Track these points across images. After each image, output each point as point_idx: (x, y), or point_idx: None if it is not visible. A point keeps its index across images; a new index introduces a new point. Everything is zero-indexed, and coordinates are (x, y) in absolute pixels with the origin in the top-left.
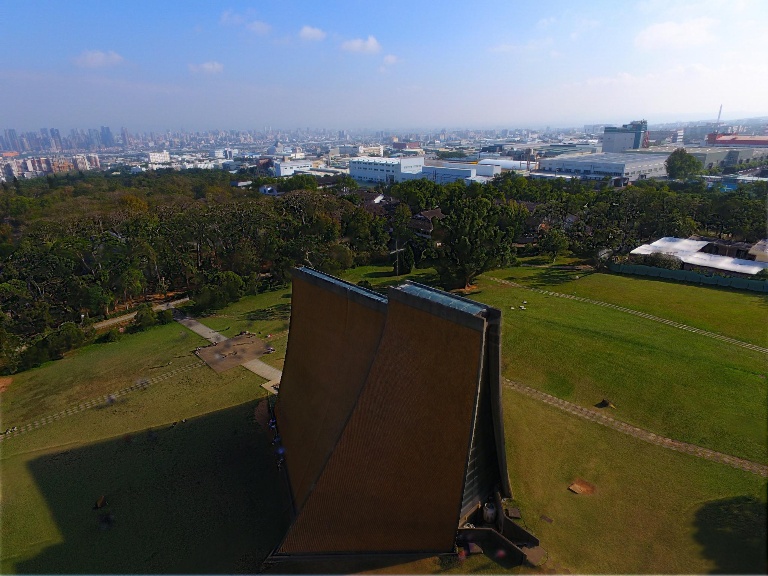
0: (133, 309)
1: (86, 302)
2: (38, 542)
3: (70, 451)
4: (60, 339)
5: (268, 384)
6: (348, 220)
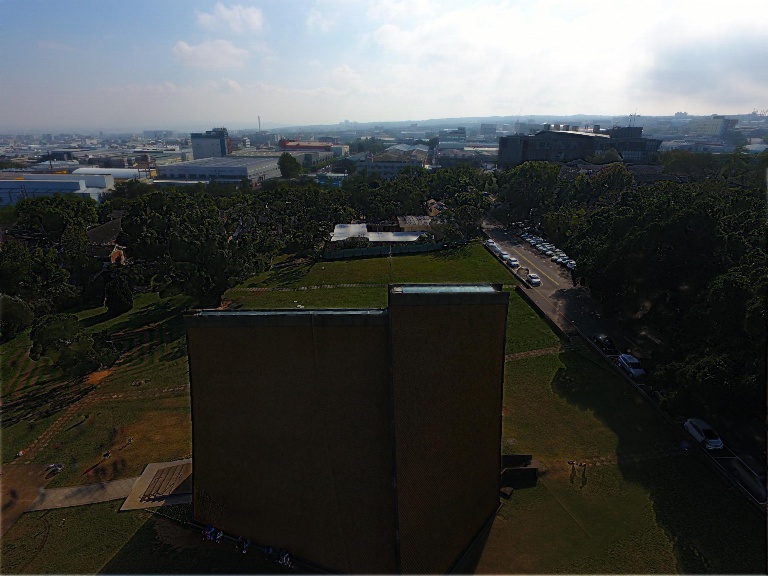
0: None
1: None
2: None
3: None
4: None
5: (130, 502)
6: None
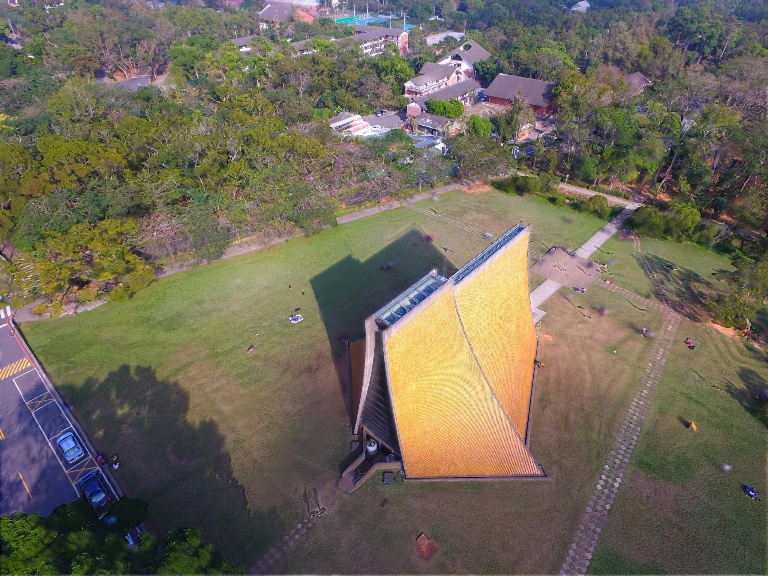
0: (612, 192)
1: (579, 167)
2: (360, 259)
3: (424, 241)
4: (524, 183)
5: None
6: None
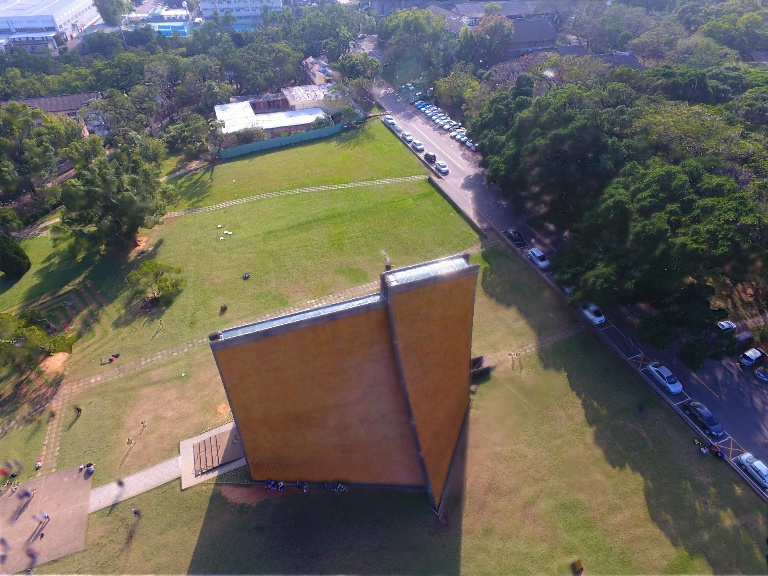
0: None
1: None
2: None
3: None
4: None
5: (187, 480)
6: None
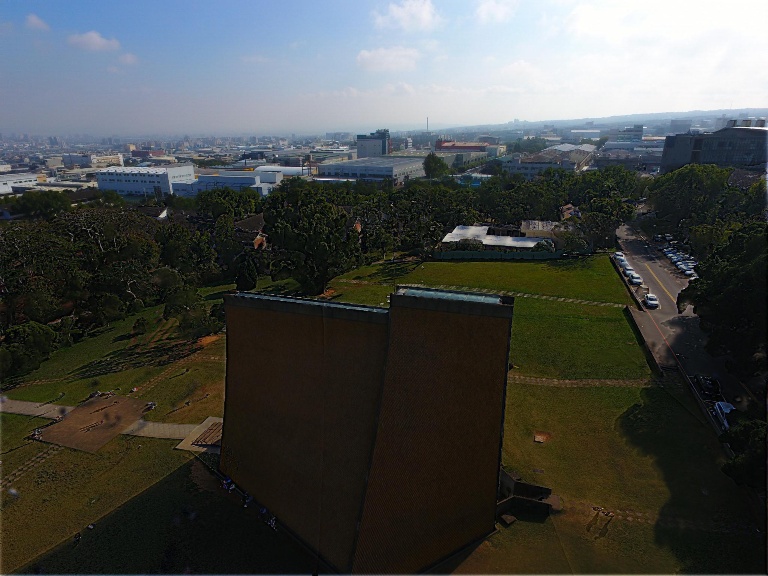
0: None
1: None
2: None
3: None
4: None
5: (184, 444)
6: (164, 239)
